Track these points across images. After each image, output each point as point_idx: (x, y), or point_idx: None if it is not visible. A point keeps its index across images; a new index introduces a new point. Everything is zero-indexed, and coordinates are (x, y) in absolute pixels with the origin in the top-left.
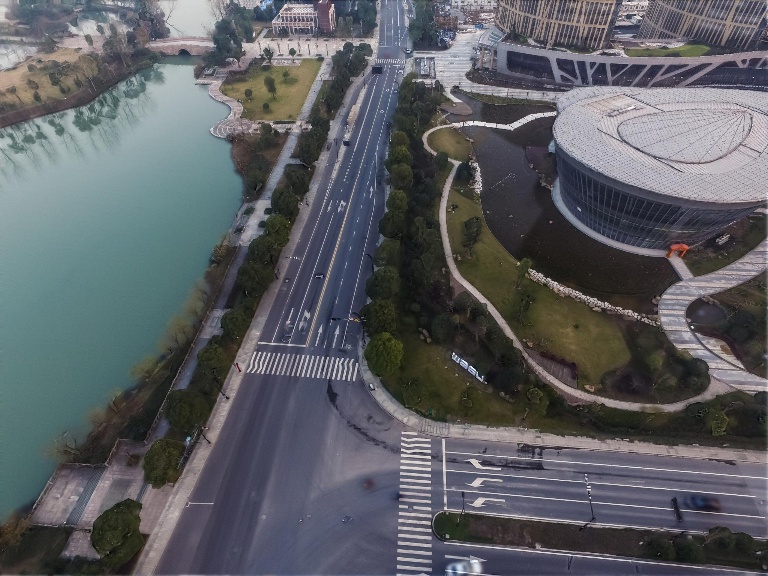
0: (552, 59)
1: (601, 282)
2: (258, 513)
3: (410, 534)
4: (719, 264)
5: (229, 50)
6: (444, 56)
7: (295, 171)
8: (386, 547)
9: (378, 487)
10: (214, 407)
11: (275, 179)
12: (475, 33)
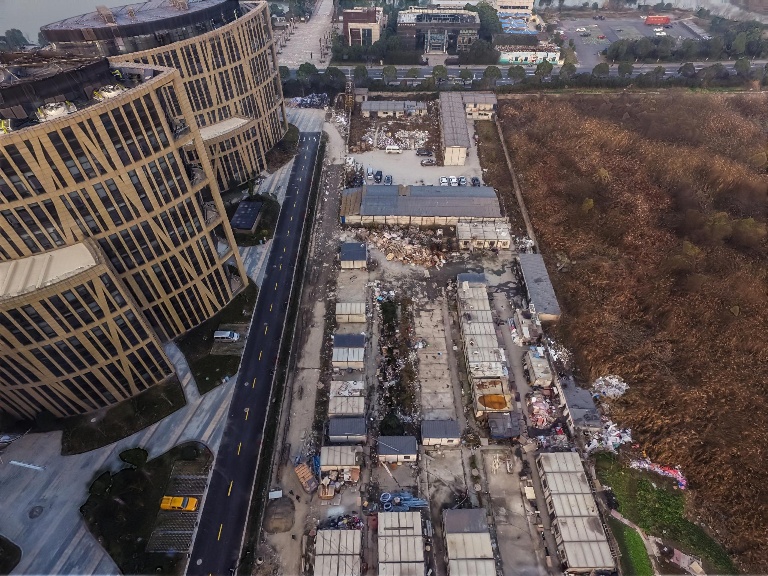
0: None
1: None
2: None
3: None
4: None
5: None
6: None
7: (10, 31)
8: None
9: None
10: None
11: None
12: (323, 121)
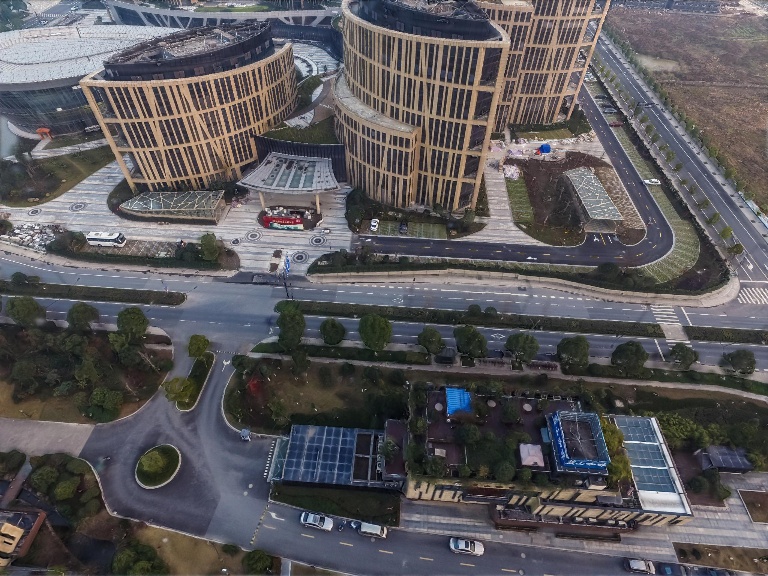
0: (139, 12)
1: None
2: None
3: None
4: (71, 143)
5: None
6: (99, 13)
7: None
8: None
9: None
10: None
11: None
12: None
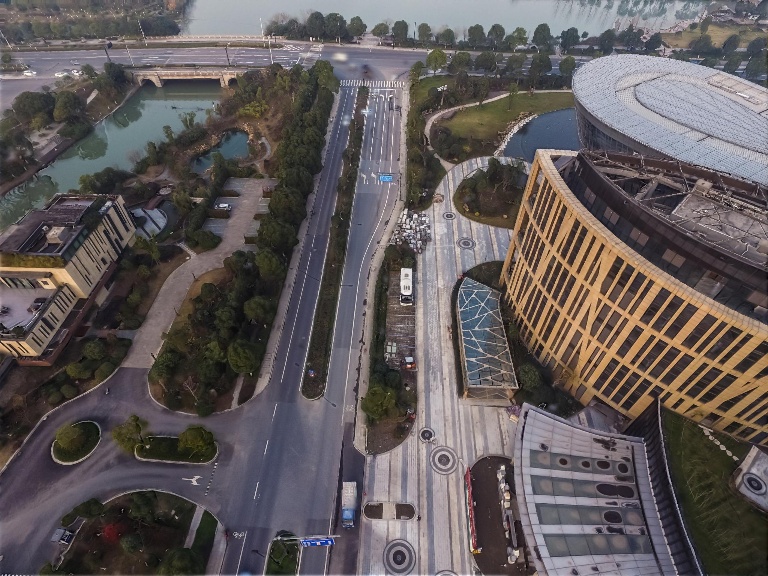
0: None
1: (532, 143)
2: (367, 58)
3: (361, 82)
4: None
5: (761, 8)
6: None
7: (572, 30)
8: (356, 78)
9: (379, 77)
10: (409, 48)
11: (584, 47)
12: None
